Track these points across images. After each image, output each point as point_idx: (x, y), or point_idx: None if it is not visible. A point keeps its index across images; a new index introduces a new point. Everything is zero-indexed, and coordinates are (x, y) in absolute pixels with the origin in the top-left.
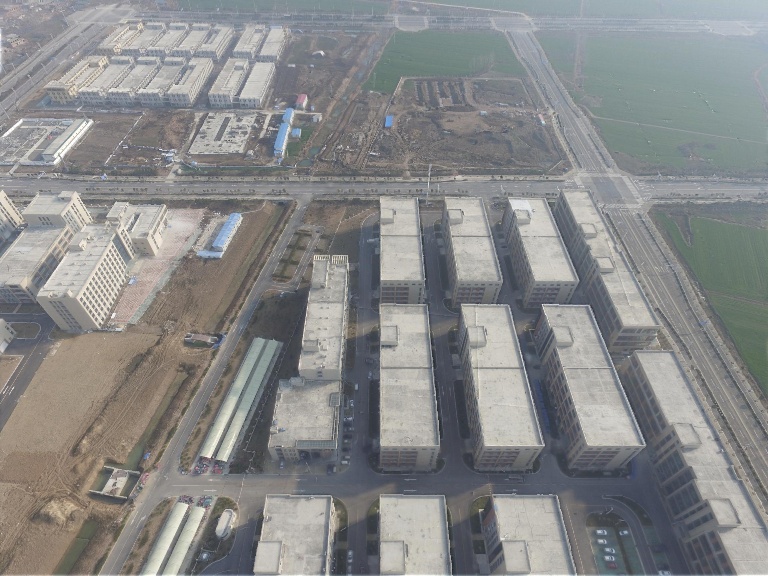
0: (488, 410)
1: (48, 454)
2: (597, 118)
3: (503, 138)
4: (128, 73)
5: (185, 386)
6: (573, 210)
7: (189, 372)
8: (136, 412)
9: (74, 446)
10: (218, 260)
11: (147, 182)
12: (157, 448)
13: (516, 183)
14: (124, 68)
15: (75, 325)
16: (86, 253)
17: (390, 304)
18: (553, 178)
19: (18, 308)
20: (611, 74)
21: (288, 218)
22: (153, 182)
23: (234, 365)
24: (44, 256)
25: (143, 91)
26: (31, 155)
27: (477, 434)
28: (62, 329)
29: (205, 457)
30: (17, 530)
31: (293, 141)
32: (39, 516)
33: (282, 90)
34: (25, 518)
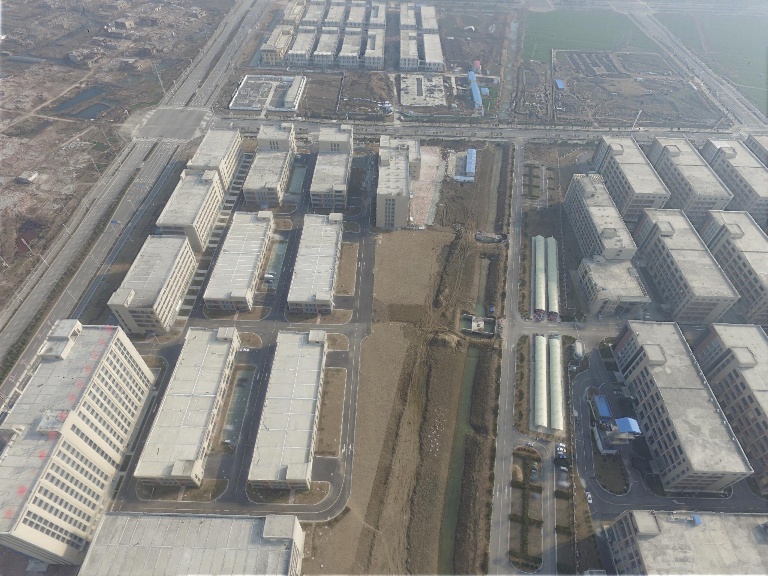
0: (764, 277)
1: (417, 306)
2: (740, 86)
3: (666, 99)
4: (315, 41)
5: (495, 267)
6: (766, 149)
7: (491, 259)
8: (468, 282)
9: (433, 302)
10: (472, 183)
11: (380, 126)
12: (498, 304)
13: (691, 134)
14: (313, 36)
15: (390, 223)
16: (393, 167)
17: (652, 209)
18: (721, 131)
19: (333, 211)
20: (737, 51)
21: (513, 155)
22: (385, 126)
23: (527, 254)
24: (347, 172)
25: (344, 54)
26: (271, 103)
27: (753, 297)
28: (377, 226)
29: (541, 310)
30: (423, 350)
31: (485, 98)
32: (437, 341)
33: (454, 57)
34: (425, 343)
